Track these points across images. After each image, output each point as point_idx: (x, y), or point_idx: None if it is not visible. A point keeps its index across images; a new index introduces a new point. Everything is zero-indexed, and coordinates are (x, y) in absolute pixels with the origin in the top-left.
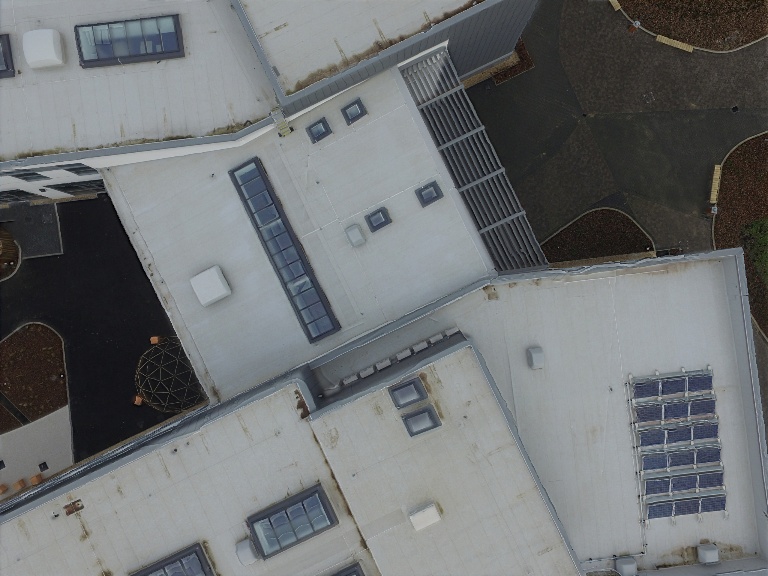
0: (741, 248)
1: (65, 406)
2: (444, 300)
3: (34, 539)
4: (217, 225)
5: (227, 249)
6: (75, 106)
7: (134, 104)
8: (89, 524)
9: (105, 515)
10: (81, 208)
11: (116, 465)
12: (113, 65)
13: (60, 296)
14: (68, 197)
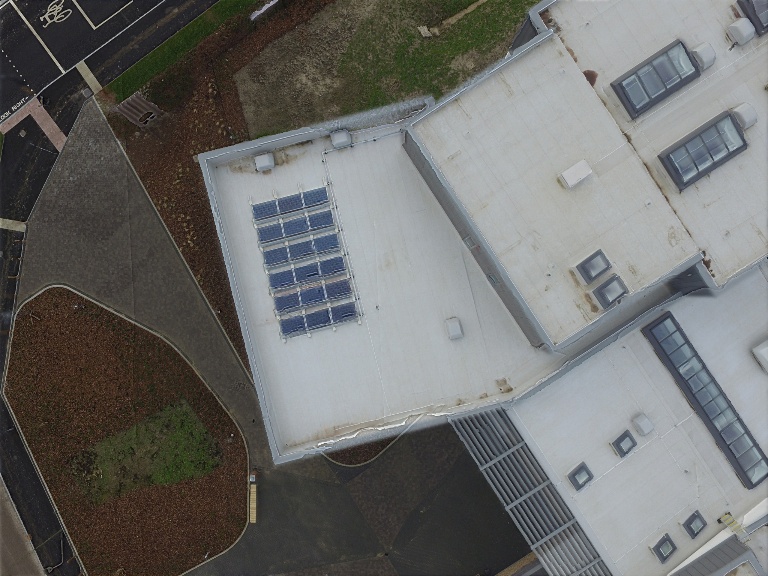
0: None
1: None
2: (559, 376)
3: None
4: None
5: (761, 392)
6: None
7: None
8: None
9: None
10: None
11: None
12: None
13: None
14: None
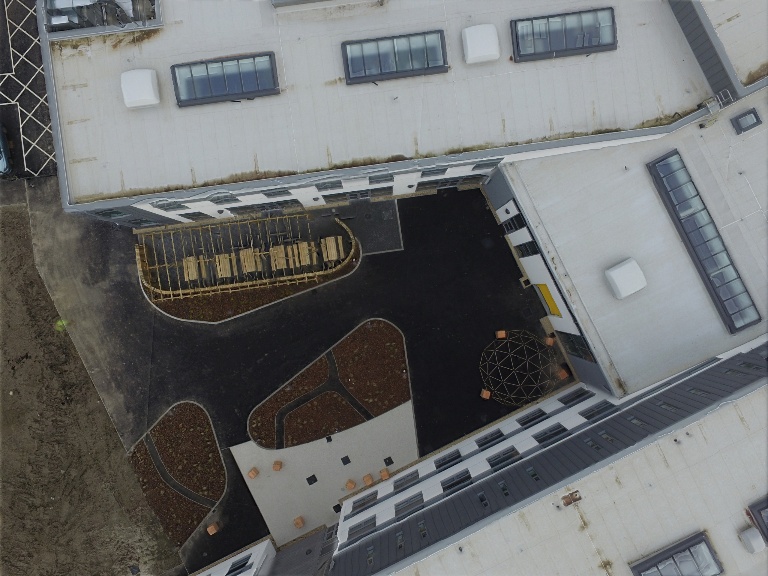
0: None
1: (408, 401)
2: None
3: (534, 530)
4: (628, 218)
5: (639, 241)
6: (505, 101)
7: (563, 98)
8: (587, 514)
9: (604, 505)
10: (421, 204)
11: (619, 456)
12: (544, 59)
13: (401, 292)
14: (408, 193)
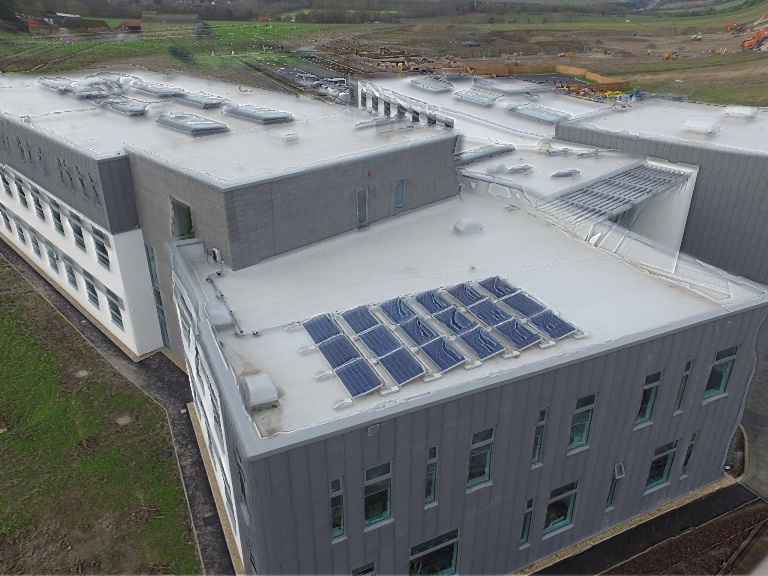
0: None
1: None
2: None
3: None
4: None
5: None
6: None
7: None
8: None
9: None
10: None
11: None
12: None
13: None
14: None
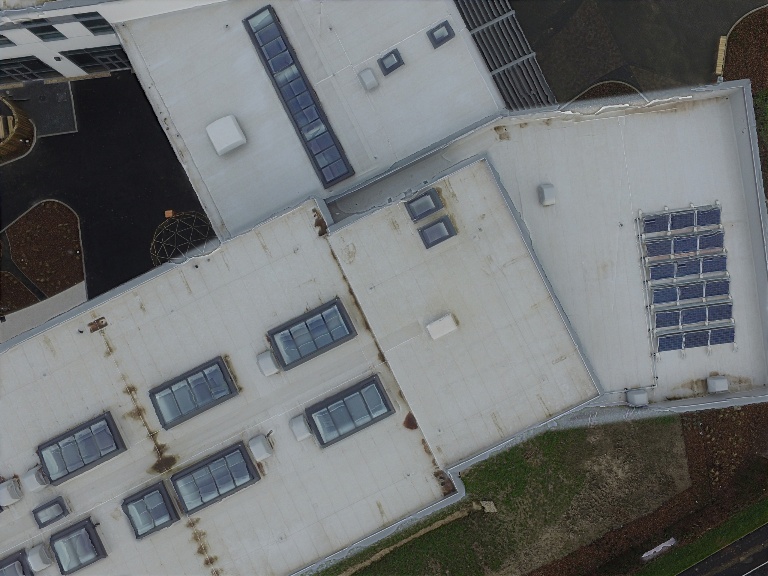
0: (748, 79)
1: (81, 282)
2: (457, 134)
3: (59, 356)
4: (231, 76)
5: (242, 99)
6: None
7: None
8: (113, 341)
9: (128, 332)
10: (95, 86)
11: (139, 281)
12: None
13: (75, 173)
14: (82, 75)
